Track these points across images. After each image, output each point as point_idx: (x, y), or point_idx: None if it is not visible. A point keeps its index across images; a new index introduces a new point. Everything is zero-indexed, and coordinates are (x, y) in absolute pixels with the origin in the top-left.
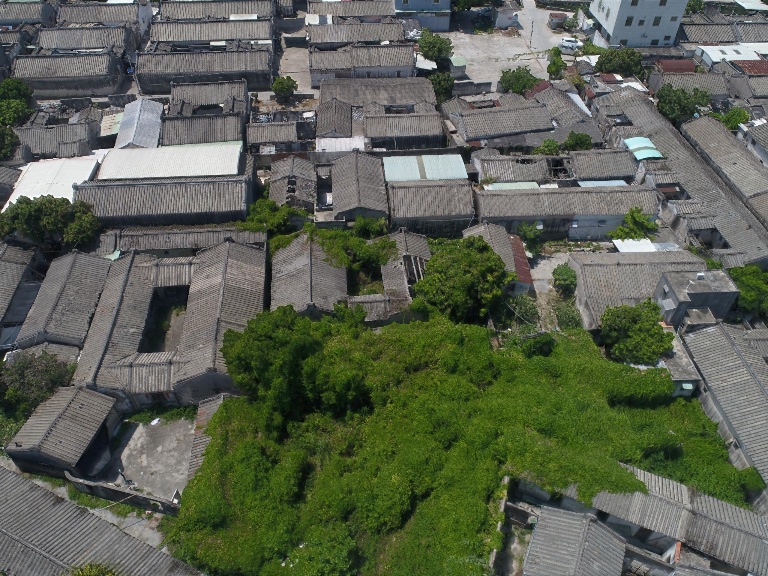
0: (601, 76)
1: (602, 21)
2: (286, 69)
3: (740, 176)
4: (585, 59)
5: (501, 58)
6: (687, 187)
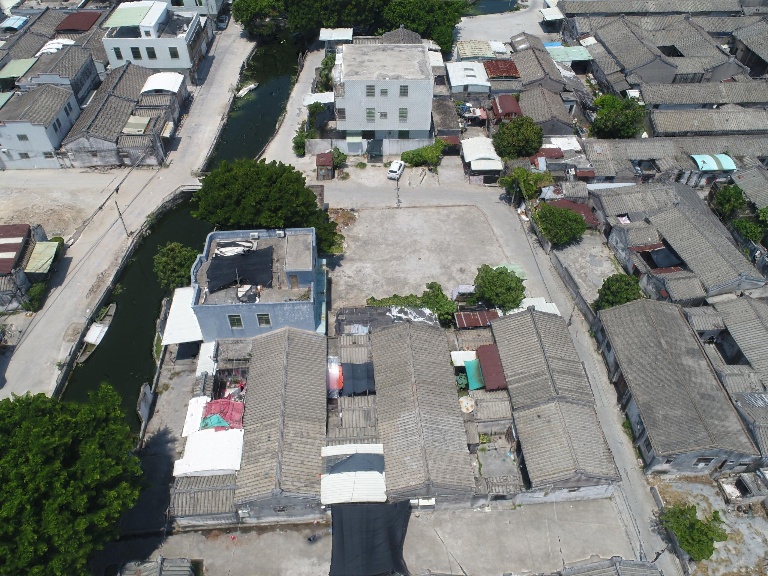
0: (549, 157)
1: (391, 126)
2: (528, 558)
3: (744, 123)
4: (480, 163)
5: (437, 238)
6: (767, 154)
